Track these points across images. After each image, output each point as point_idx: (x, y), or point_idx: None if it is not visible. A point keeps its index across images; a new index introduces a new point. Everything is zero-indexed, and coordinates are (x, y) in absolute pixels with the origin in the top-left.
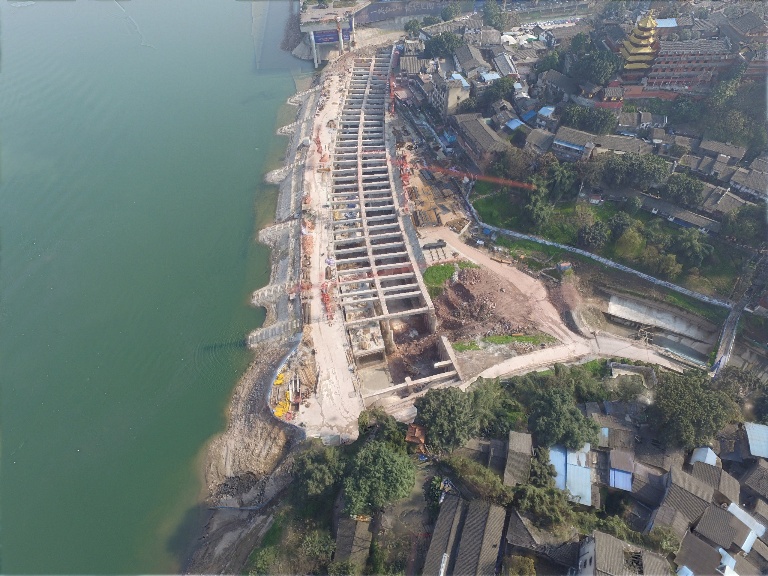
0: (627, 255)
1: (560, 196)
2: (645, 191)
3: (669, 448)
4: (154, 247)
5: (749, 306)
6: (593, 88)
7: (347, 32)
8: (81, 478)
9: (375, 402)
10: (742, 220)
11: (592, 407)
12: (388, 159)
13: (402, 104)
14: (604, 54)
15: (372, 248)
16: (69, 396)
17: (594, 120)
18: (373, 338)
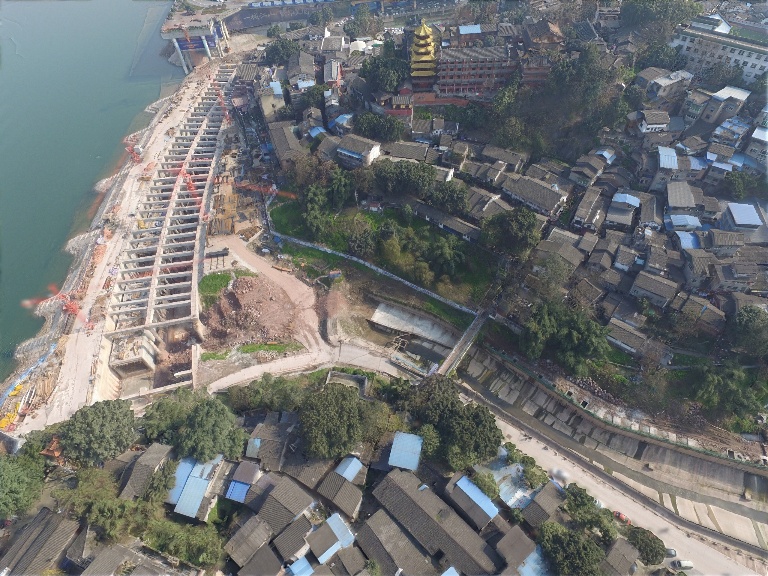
0: (400, 262)
1: (341, 204)
2: (422, 198)
3: (311, 458)
4: None
5: (491, 313)
6: (382, 96)
7: (211, 39)
8: None
9: None
10: (489, 227)
11: (271, 417)
12: (212, 167)
13: (238, 111)
14: (388, 62)
15: (161, 257)
16: None
17: (382, 128)
18: (133, 348)
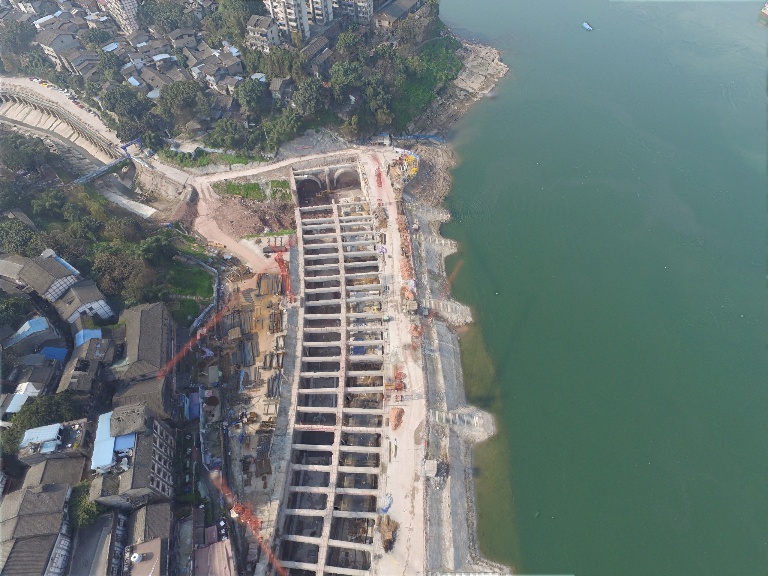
0: None
1: None
2: None
3: None
4: (590, 306)
5: (60, 181)
6: None
7: None
8: (526, 153)
9: (351, 170)
10: None
11: (226, 117)
12: (294, 407)
13: None
14: None
15: None
16: (568, 188)
17: None
18: None
